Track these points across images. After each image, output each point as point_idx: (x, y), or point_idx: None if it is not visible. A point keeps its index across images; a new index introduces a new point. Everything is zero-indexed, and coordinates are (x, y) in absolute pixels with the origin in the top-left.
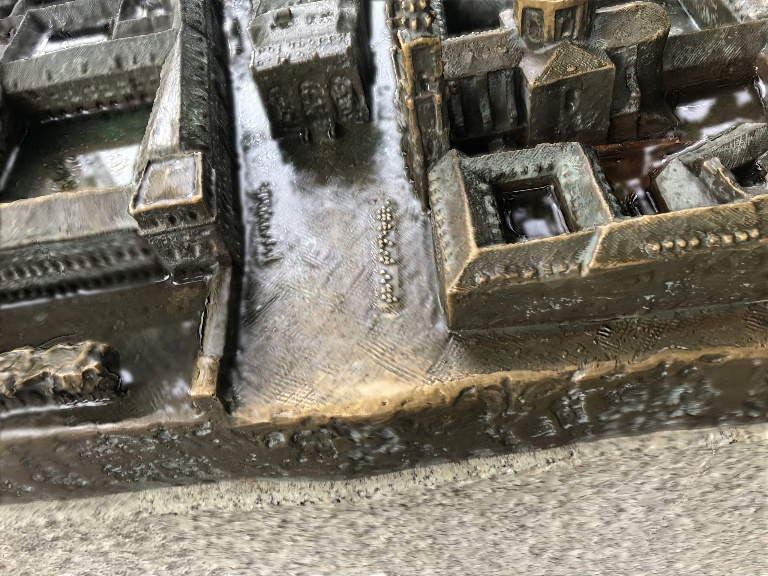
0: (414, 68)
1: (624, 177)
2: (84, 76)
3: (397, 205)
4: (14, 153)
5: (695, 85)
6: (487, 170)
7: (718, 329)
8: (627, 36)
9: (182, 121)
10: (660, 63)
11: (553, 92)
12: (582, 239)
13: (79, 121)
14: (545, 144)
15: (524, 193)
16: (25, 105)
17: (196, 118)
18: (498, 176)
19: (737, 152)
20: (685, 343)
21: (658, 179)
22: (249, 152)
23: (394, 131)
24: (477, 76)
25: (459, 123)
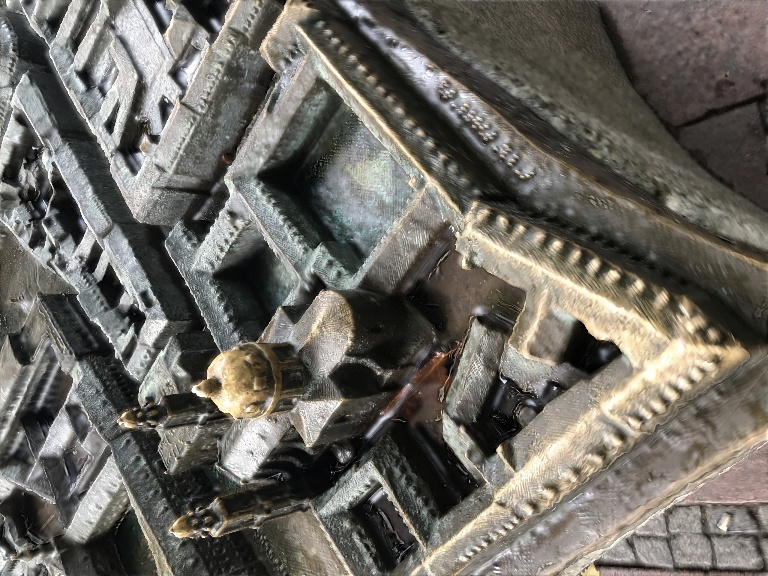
0: (234, 529)
1: (432, 407)
2: (103, 510)
3: None
4: (123, 571)
5: (423, 272)
6: (339, 507)
7: (564, 535)
8: (333, 355)
9: (169, 561)
10: (377, 322)
11: (326, 433)
12: (420, 574)
13: (130, 515)
14: (354, 474)
15: (375, 499)
16: (98, 538)
17: (174, 541)
18: (349, 506)
19: (480, 376)
20: (549, 559)
21: (445, 437)
22: (222, 482)
23: None
24: (276, 446)
25: (299, 465)
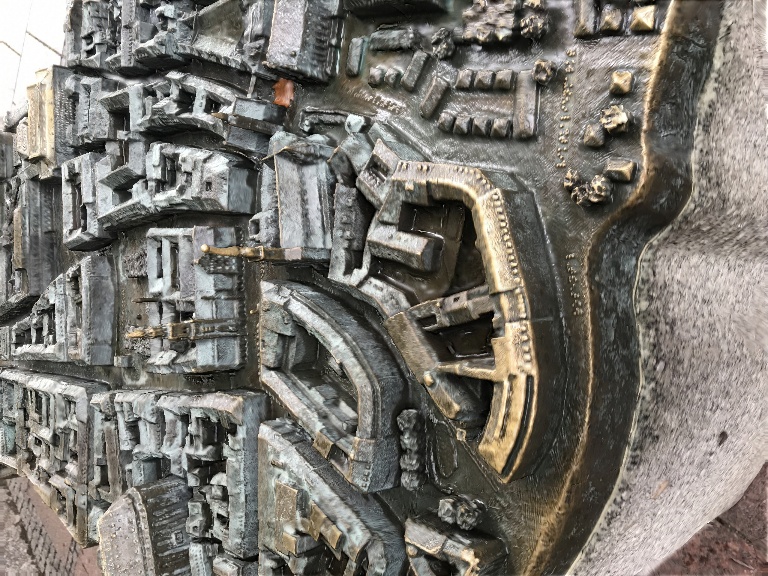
0: None
1: None
2: None
3: None
4: None
5: None
6: None
7: None
8: None
9: None
10: None
11: None
12: None
13: None
14: None
15: None
16: None
17: None
18: None
19: None
20: None
21: None
22: None
23: (16, 363)
24: None
25: None
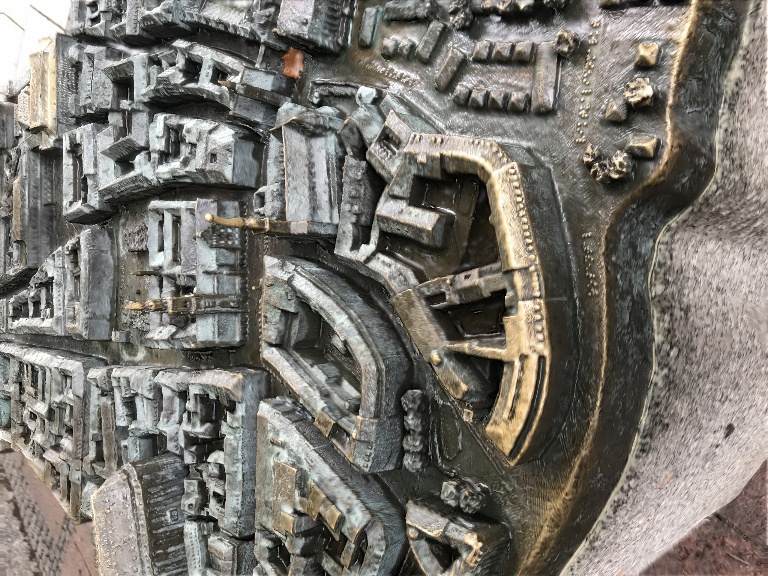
0: None
1: None
2: None
3: (4, 335)
4: None
5: None
6: None
7: None
8: None
9: None
10: None
11: None
12: None
13: None
14: None
15: None
16: None
17: None
18: None
19: None
20: None
21: None
22: None
23: None
24: None
25: None
